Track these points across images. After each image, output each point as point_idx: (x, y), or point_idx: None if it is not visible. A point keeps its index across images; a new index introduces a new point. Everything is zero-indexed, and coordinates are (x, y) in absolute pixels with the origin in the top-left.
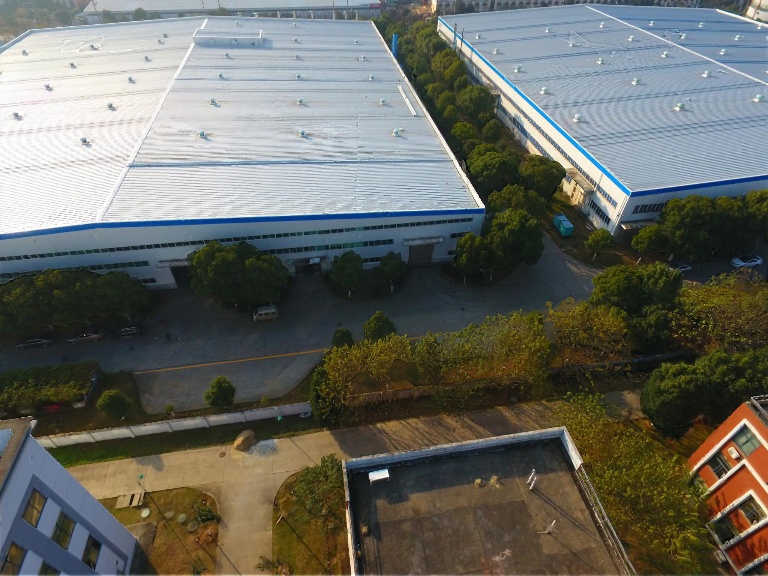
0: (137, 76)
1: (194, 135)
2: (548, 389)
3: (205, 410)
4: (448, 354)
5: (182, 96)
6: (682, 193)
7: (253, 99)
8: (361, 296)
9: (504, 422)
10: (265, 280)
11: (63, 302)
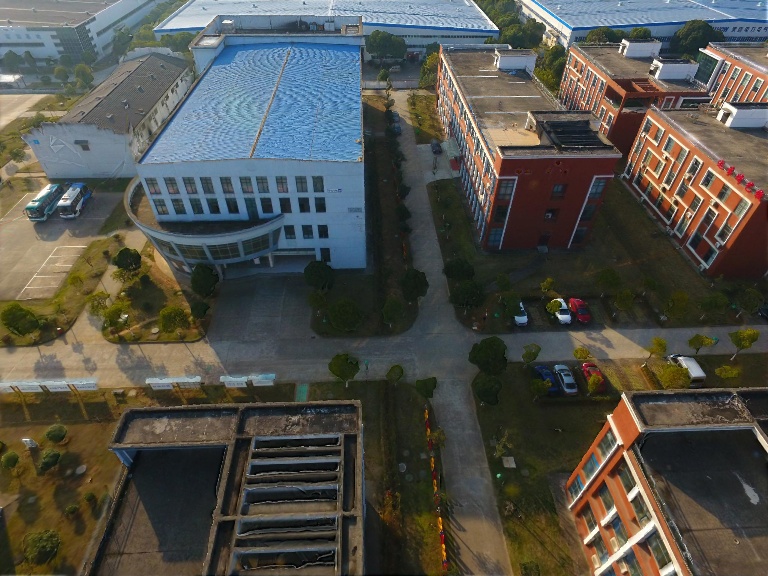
0: None
1: None
2: None
3: None
4: None
5: None
6: None
7: None
8: None
9: None
10: (399, 46)
11: None
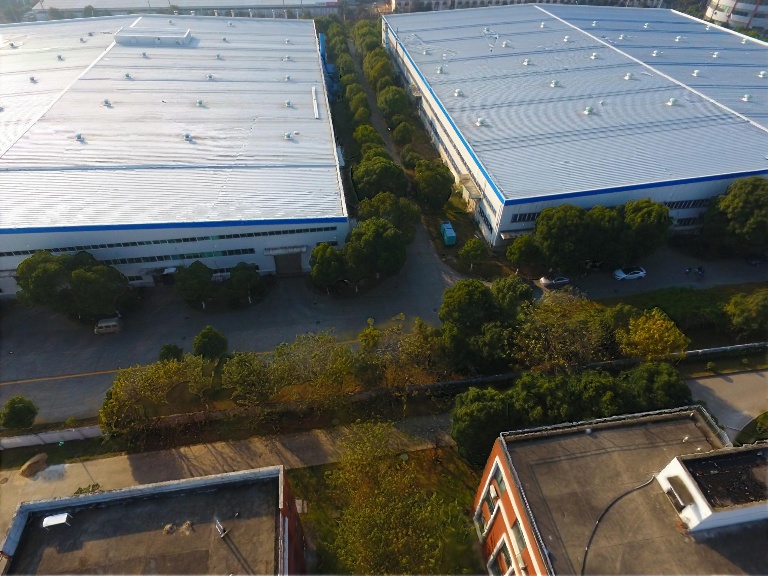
0: (42, 76)
1: (71, 138)
2: (374, 411)
3: (8, 431)
4: (247, 375)
5: (78, 97)
6: (561, 202)
7: (152, 100)
8: (216, 308)
9: (317, 447)
10: (93, 292)
11: None
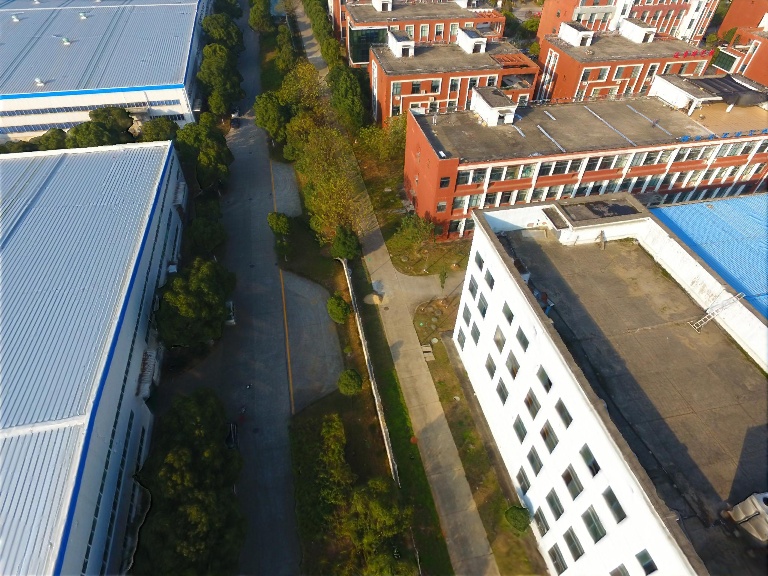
0: None
1: None
2: None
3: None
4: None
5: None
6: None
7: None
8: (219, 253)
9: None
10: None
11: (218, 454)
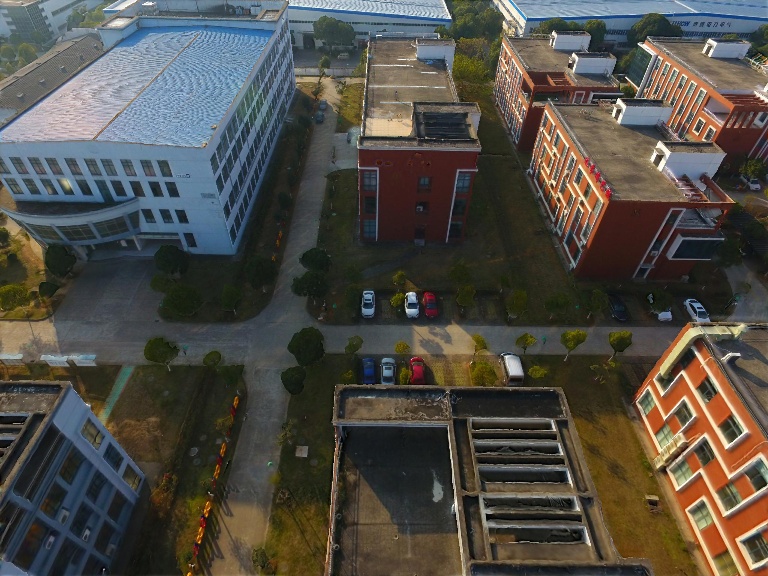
0: None
1: None
2: None
3: None
4: None
5: None
6: None
7: None
8: None
9: None
10: (346, 33)
11: None
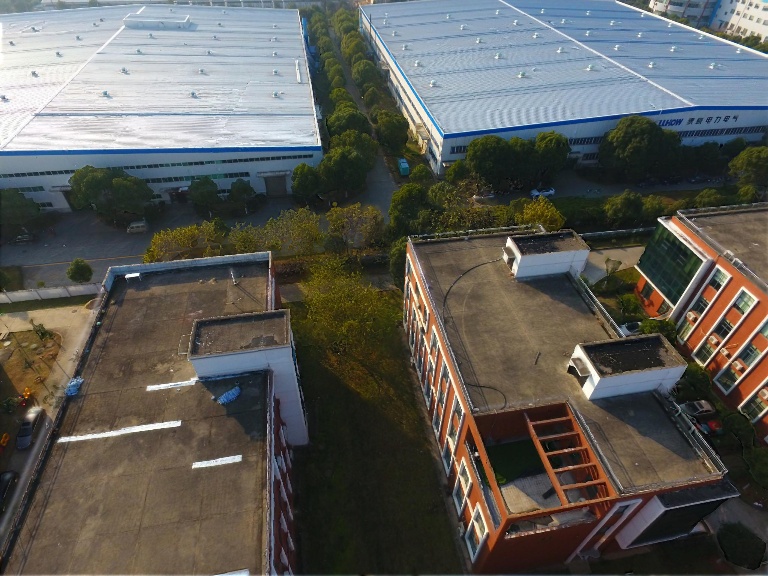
0: (65, 51)
1: (99, 94)
2: None
3: None
4: (246, 236)
5: (99, 66)
6: None
7: (161, 69)
8: (220, 217)
9: (297, 292)
10: (129, 195)
11: None
